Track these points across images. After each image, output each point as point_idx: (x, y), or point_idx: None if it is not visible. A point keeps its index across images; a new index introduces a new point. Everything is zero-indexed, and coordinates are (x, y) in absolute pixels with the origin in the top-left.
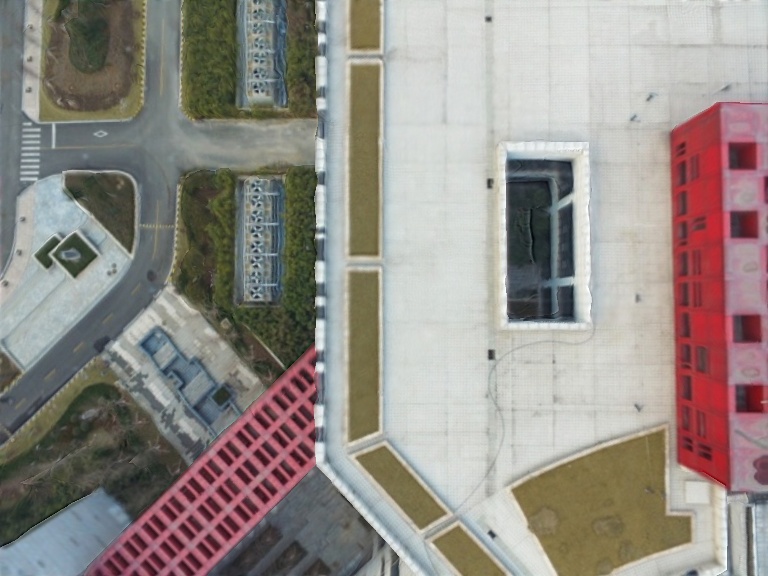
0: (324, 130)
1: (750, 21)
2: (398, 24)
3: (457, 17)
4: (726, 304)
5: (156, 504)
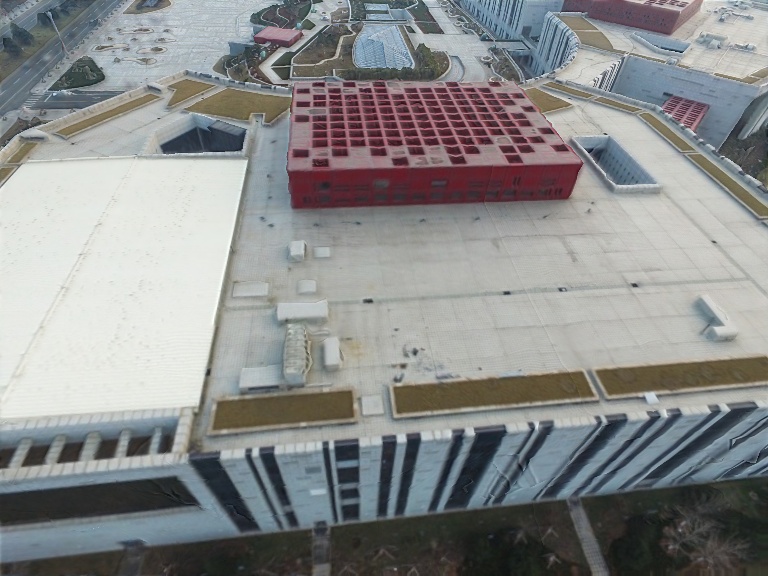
0: (761, 190)
1: None
2: (767, 236)
3: (735, 242)
4: None
5: (699, 120)
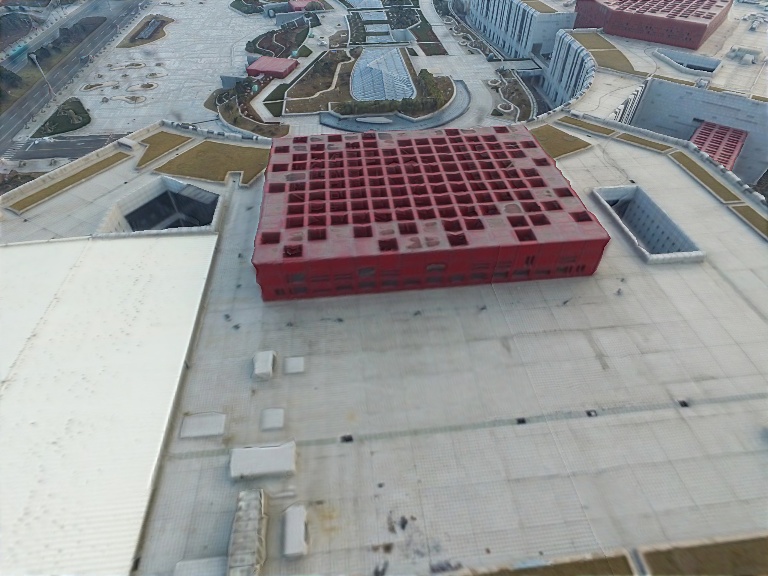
0: None
1: (567, 348)
2: None
3: None
4: (556, 168)
5: (738, 151)
